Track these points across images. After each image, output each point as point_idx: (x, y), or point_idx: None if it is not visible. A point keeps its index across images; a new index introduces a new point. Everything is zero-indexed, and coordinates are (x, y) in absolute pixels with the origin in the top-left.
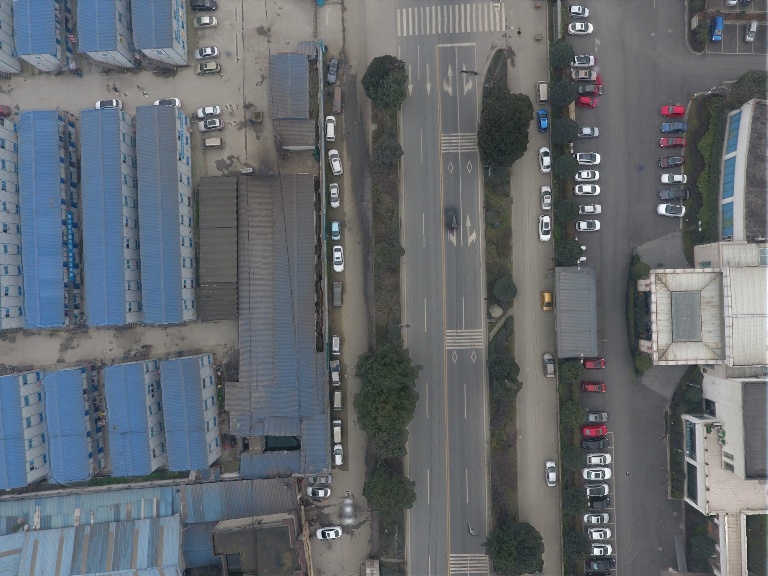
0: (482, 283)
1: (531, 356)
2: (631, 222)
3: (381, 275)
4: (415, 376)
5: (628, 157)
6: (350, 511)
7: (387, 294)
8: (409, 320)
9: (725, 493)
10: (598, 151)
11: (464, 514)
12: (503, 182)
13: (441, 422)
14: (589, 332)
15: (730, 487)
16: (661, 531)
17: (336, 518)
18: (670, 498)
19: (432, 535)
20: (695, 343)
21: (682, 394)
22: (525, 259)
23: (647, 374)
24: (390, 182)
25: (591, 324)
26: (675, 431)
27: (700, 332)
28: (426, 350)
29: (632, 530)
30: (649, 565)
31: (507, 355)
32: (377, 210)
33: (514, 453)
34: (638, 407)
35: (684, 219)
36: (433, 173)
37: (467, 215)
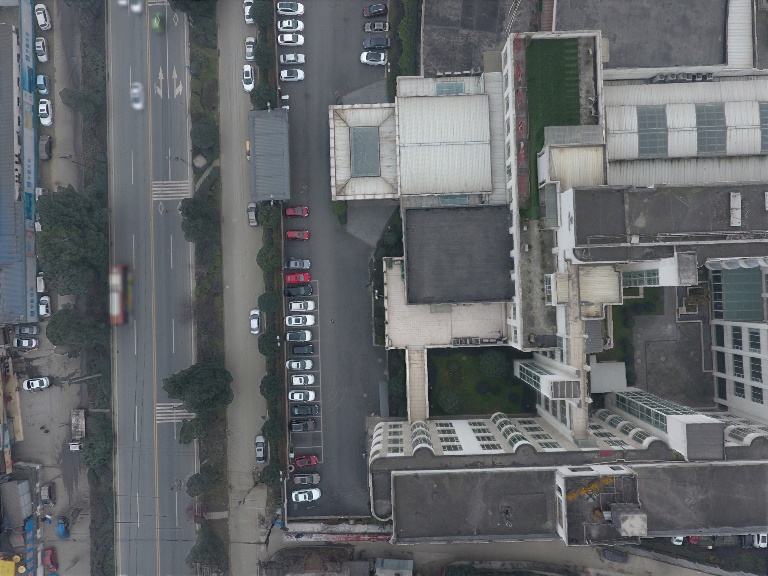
0: (188, 134)
1: (238, 207)
2: (336, 72)
3: (87, 127)
4: (96, 215)
5: (334, 8)
6: (59, 363)
7: (93, 146)
8: (116, 172)
9: (409, 329)
10: (304, 2)
11: (170, 364)
12: (207, 33)
13: (147, 273)
14: (283, 176)
15: (414, 323)
16: (366, 378)
17: (45, 370)
18: (375, 345)
19: (138, 385)
20: (374, 178)
21: (383, 240)
22: (232, 111)
23: (351, 222)
24: (96, 35)
25: (285, 168)
26: (375, 276)
27: (378, 167)
28: (133, 202)
29: (337, 377)
30: (354, 411)
31: (211, 204)
32: (84, 64)
33: (220, 302)
34: (343, 255)
35: (387, 68)
36: (140, 26)
37: (173, 67)
